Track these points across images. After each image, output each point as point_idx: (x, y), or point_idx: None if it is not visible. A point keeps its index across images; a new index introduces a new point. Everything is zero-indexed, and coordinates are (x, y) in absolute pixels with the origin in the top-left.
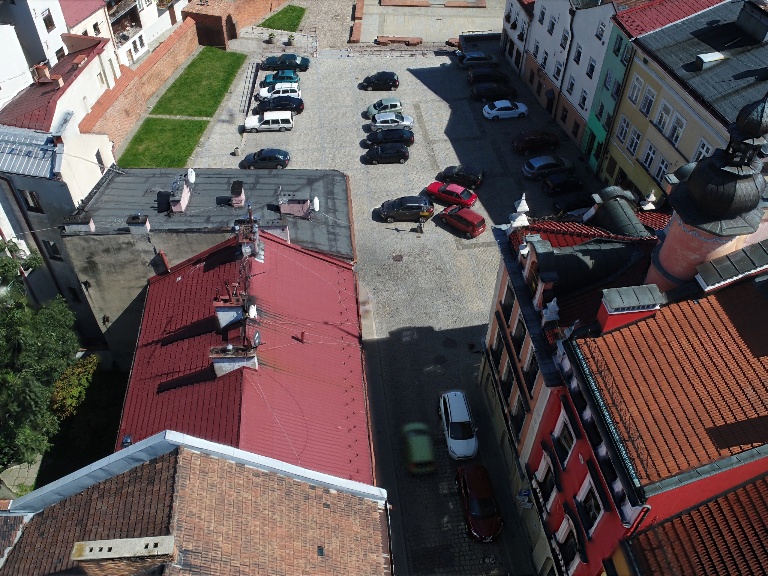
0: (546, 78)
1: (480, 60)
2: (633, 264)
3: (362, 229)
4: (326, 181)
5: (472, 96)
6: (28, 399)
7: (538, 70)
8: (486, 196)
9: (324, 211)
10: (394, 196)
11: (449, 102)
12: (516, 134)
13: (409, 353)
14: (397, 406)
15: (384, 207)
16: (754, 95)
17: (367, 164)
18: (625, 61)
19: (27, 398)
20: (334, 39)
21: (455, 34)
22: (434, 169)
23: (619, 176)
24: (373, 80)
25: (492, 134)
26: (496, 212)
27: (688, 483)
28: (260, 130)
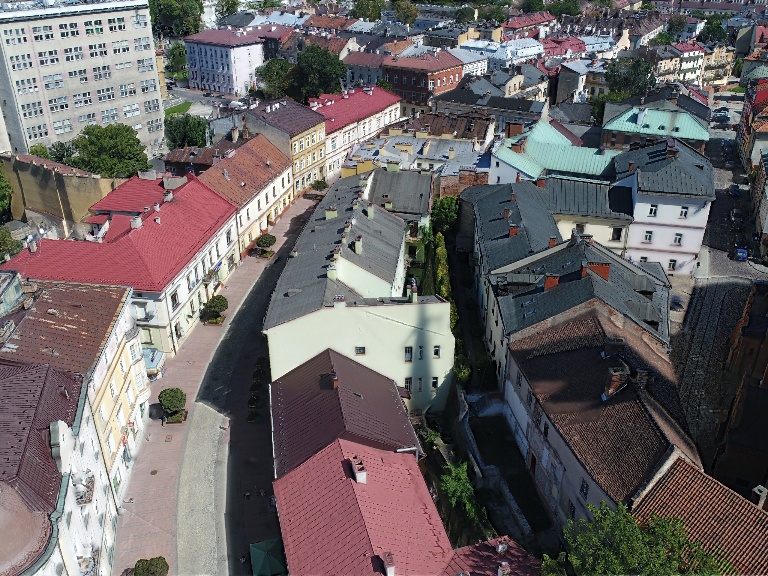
0: None
1: None
2: None
3: None
4: None
5: None
6: (654, 80)
7: None
8: None
9: None
10: None
11: None
12: None
13: (715, 139)
14: (710, 142)
15: None
16: None
17: (711, 122)
18: None
19: (654, 80)
20: None
21: None
22: None
23: None
24: (719, 109)
25: None
26: None
27: (763, 89)
28: None
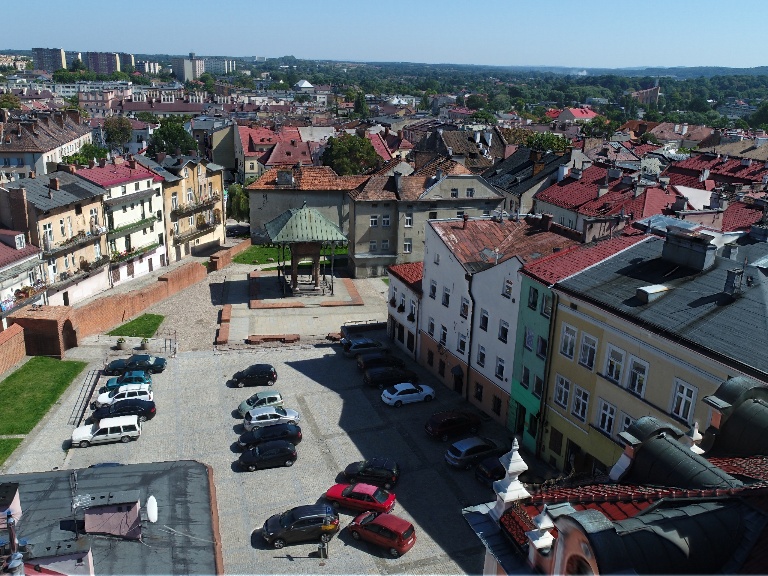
0: (449, 355)
1: (368, 347)
2: (758, 536)
3: (237, 563)
4: (174, 476)
5: (366, 383)
6: None
7: (438, 346)
8: (406, 496)
9: (168, 524)
10: (281, 510)
11: (339, 392)
12: (426, 419)
13: None
14: None
15: (268, 526)
16: (725, 320)
17: (241, 472)
18: (546, 313)
19: None
20: (197, 342)
21: (335, 329)
22: (332, 469)
23: (569, 451)
24: (245, 374)
25: (398, 422)
26: (424, 516)
27: None
28: (93, 443)
